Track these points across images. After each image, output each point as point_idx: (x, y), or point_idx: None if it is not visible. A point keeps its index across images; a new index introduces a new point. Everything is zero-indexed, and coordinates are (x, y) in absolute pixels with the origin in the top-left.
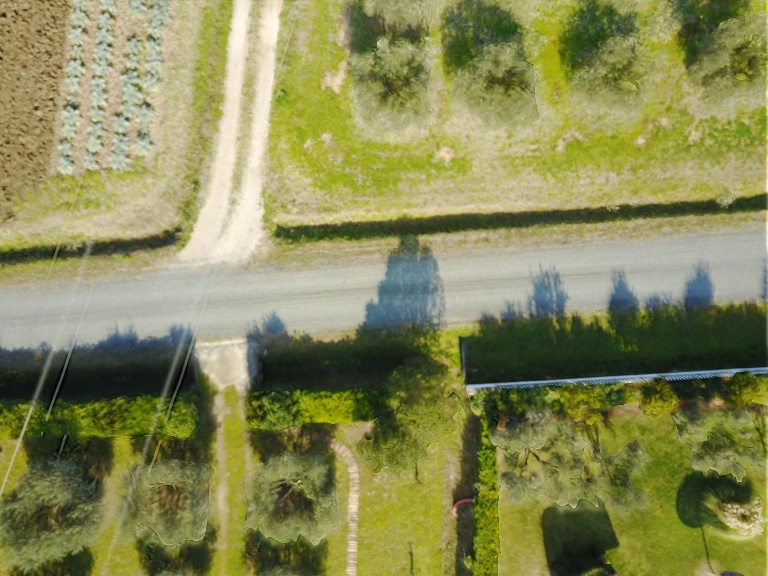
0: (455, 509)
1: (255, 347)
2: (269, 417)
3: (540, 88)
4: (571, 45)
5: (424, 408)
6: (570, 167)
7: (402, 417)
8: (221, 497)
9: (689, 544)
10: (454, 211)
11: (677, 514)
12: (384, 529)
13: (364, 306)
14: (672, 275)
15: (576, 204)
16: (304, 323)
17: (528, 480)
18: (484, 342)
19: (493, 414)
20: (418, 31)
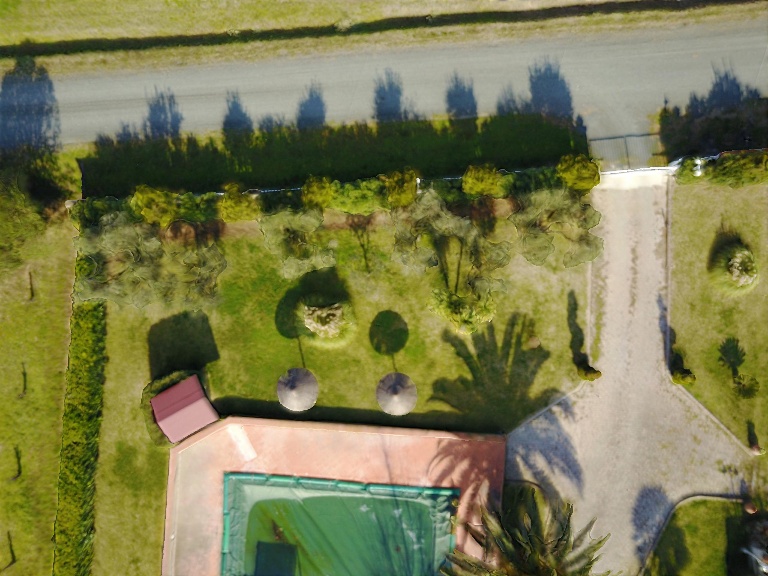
0: None
1: None
2: None
3: None
4: None
5: None
6: None
7: None
8: None
9: (286, 355)
10: (77, 35)
11: (275, 326)
12: None
13: None
14: (285, 96)
15: (199, 29)
16: None
17: None
18: (100, 163)
19: (86, 225)
20: None
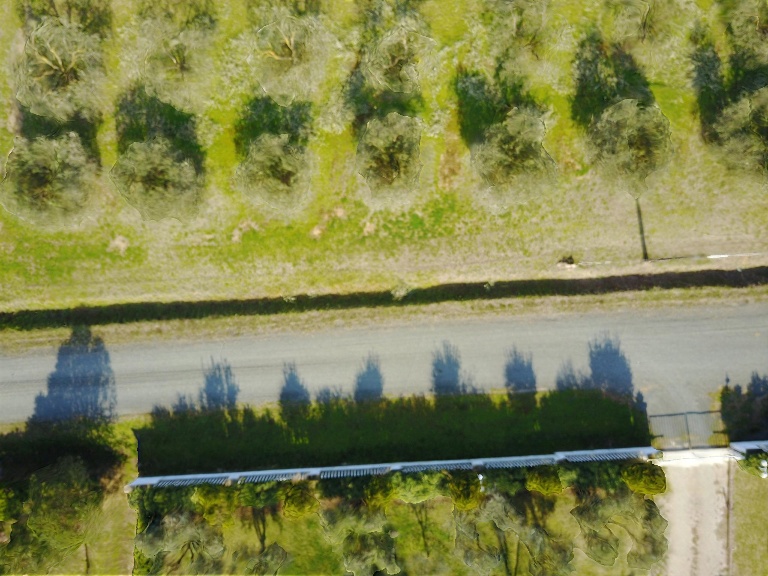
0: None
1: None
2: None
3: (216, 177)
4: (247, 134)
5: (42, 518)
6: (246, 257)
7: None
8: None
9: None
10: (132, 300)
11: None
12: None
13: (33, 399)
14: (342, 368)
15: (254, 294)
16: None
17: None
18: (156, 434)
19: (145, 513)
20: (81, 121)
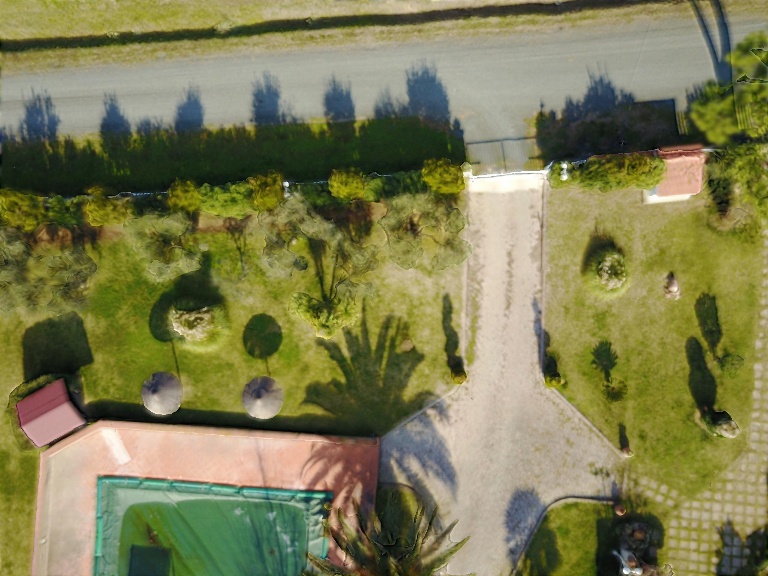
0: None
1: None
2: None
3: None
4: None
5: None
6: None
7: None
8: None
9: (160, 358)
10: None
11: (149, 329)
12: None
13: None
14: (163, 98)
15: (78, 30)
16: None
17: None
18: None
19: None
20: None
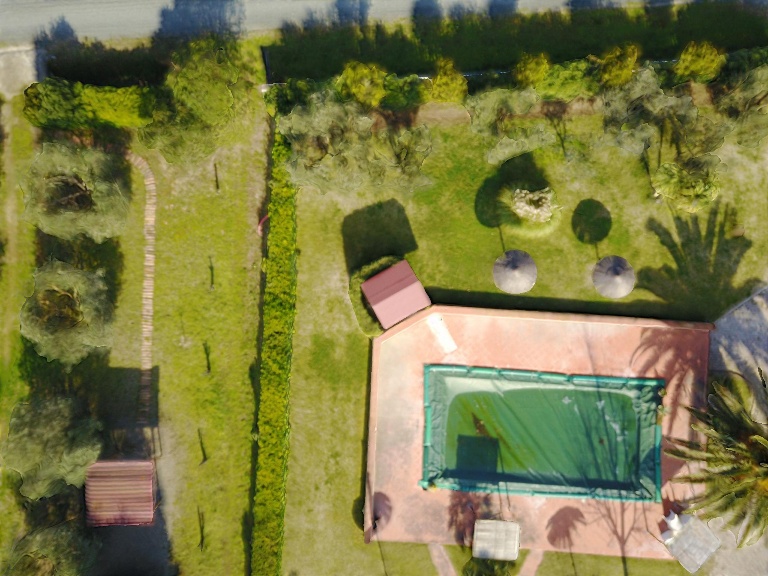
0: (260, 227)
1: (44, 54)
2: (44, 104)
3: None
4: None
5: (194, 72)
6: None
7: (177, 90)
8: (9, 210)
9: (487, 244)
10: None
11: (475, 215)
12: (183, 243)
13: (159, 11)
14: None
15: None
16: (96, 29)
17: (316, 167)
18: (286, 51)
19: (285, 108)
20: None
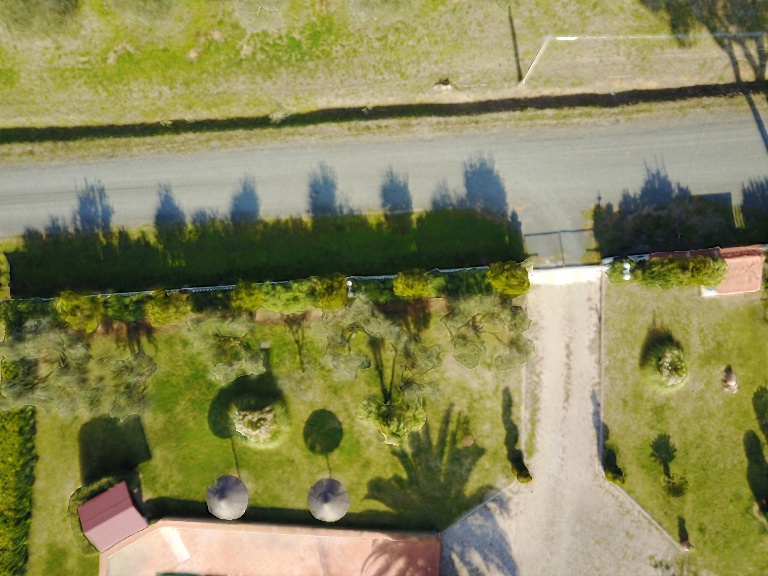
0: None
1: None
2: None
3: None
4: None
5: None
6: (121, 80)
7: None
8: None
9: (219, 455)
10: (5, 125)
11: (208, 425)
12: None
13: None
14: (219, 189)
15: (131, 119)
16: None
17: (34, 391)
18: (29, 258)
19: (11, 326)
20: None
